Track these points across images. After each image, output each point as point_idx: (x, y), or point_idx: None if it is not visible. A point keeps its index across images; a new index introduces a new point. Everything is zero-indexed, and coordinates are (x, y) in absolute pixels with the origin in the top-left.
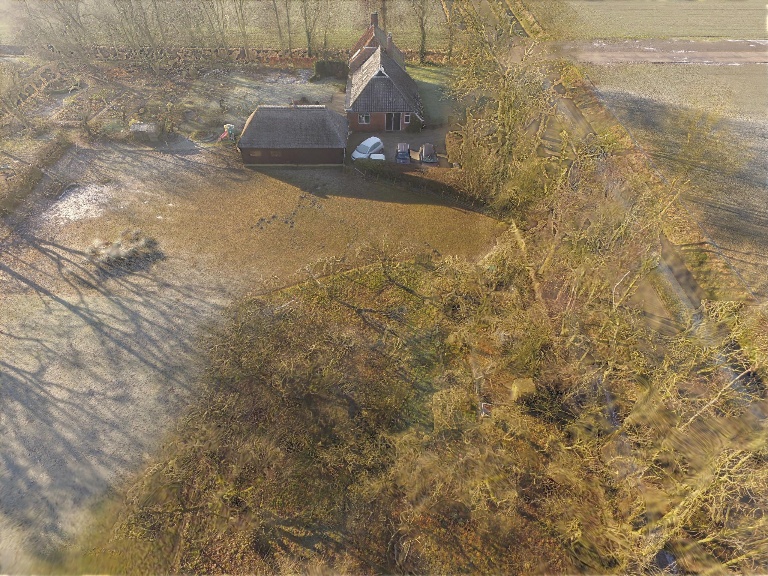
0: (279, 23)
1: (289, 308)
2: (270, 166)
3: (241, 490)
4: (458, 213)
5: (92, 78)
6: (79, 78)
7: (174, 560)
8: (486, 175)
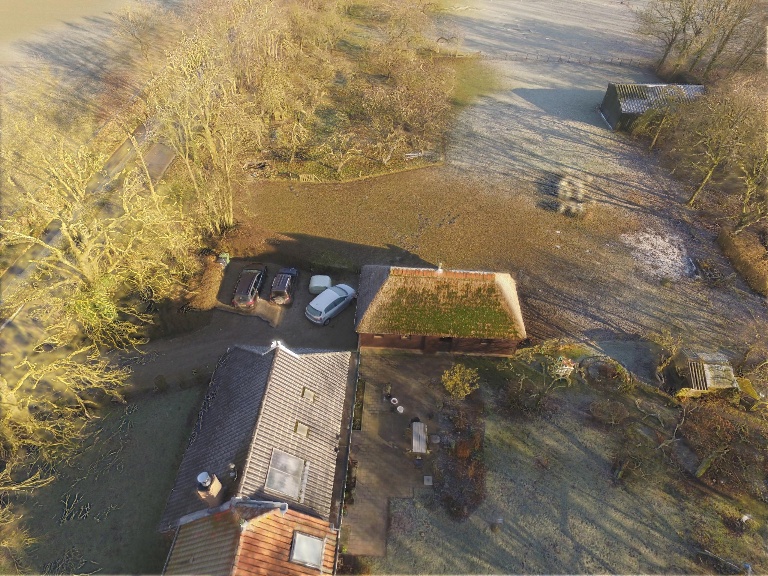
0: None
1: (404, 111)
2: None
3: None
4: None
5: None
6: None
7: None
8: None
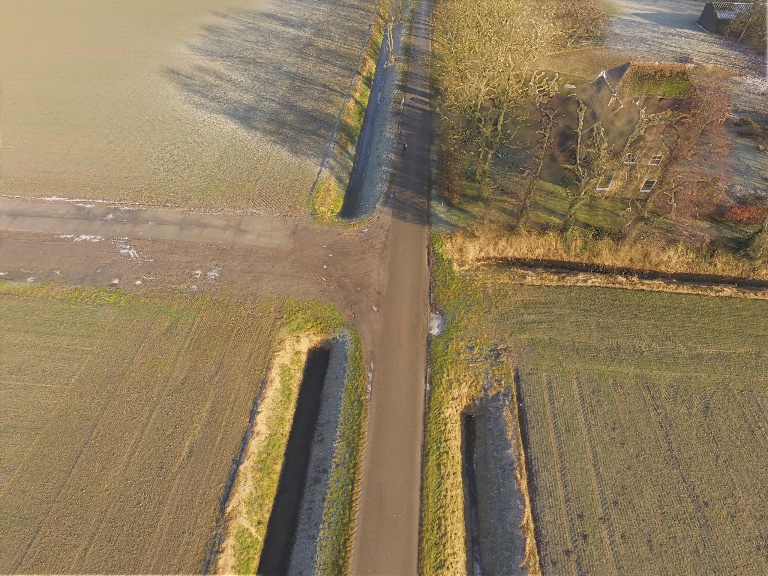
0: None
1: None
2: None
3: None
4: None
5: None
6: None
7: None
8: None
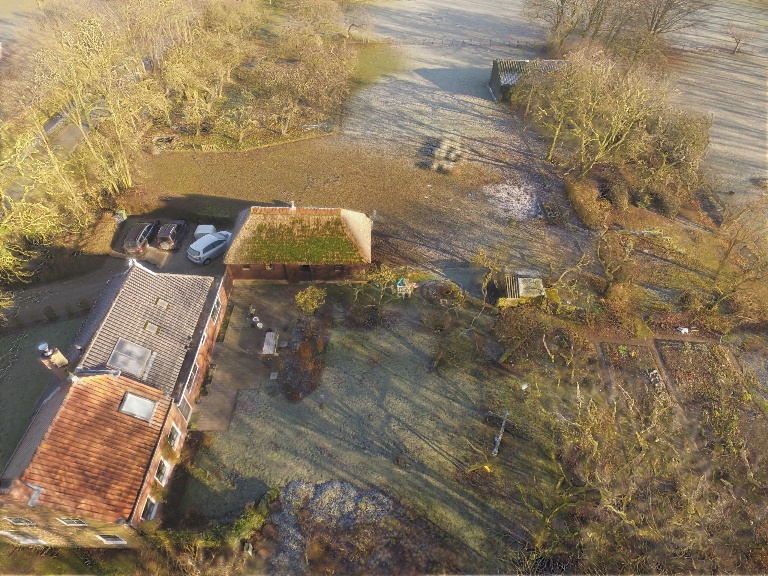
0: None
1: (300, 87)
2: None
3: None
4: None
5: None
6: None
7: None
8: None
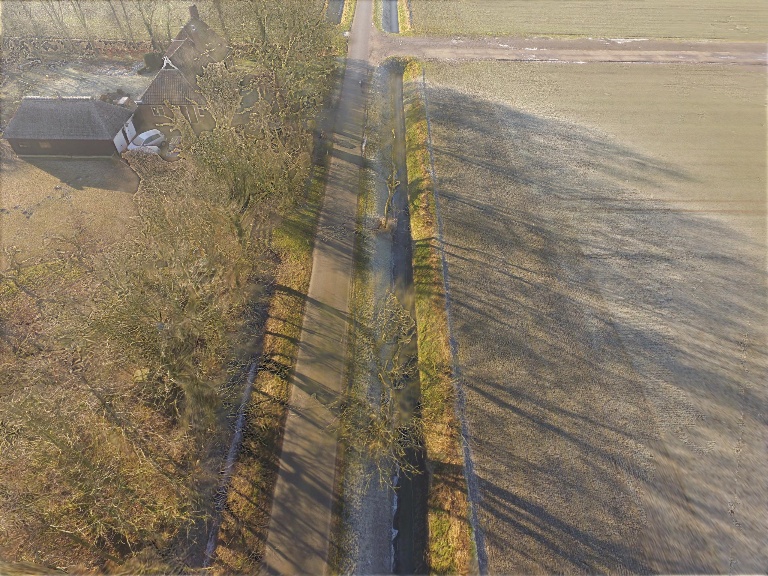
0: (116, 14)
1: None
2: (44, 157)
3: None
4: None
5: None
6: None
7: None
8: None
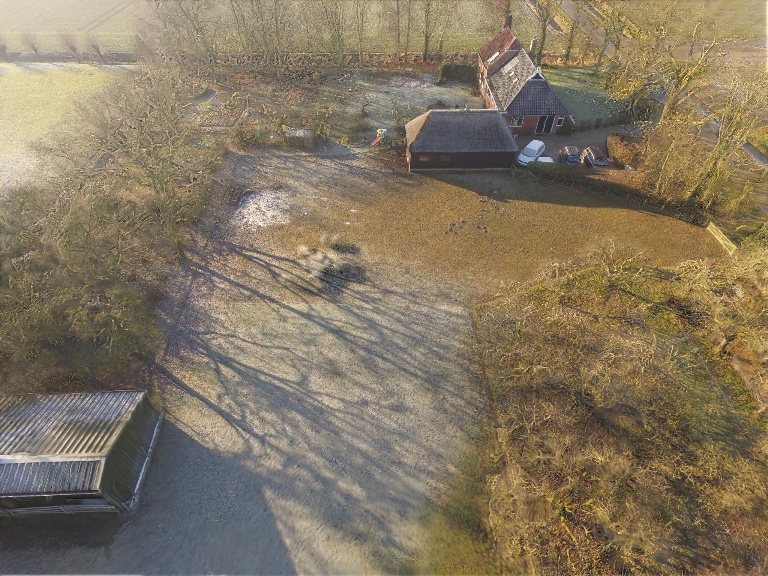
0: (399, 27)
1: (563, 315)
2: (436, 170)
3: (582, 503)
4: (647, 216)
5: (216, 84)
6: (204, 84)
7: (534, 575)
8: (685, 178)
